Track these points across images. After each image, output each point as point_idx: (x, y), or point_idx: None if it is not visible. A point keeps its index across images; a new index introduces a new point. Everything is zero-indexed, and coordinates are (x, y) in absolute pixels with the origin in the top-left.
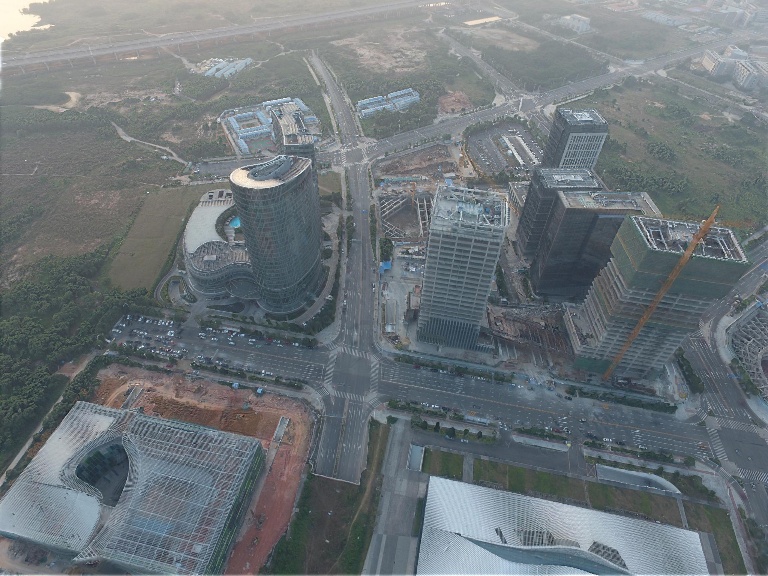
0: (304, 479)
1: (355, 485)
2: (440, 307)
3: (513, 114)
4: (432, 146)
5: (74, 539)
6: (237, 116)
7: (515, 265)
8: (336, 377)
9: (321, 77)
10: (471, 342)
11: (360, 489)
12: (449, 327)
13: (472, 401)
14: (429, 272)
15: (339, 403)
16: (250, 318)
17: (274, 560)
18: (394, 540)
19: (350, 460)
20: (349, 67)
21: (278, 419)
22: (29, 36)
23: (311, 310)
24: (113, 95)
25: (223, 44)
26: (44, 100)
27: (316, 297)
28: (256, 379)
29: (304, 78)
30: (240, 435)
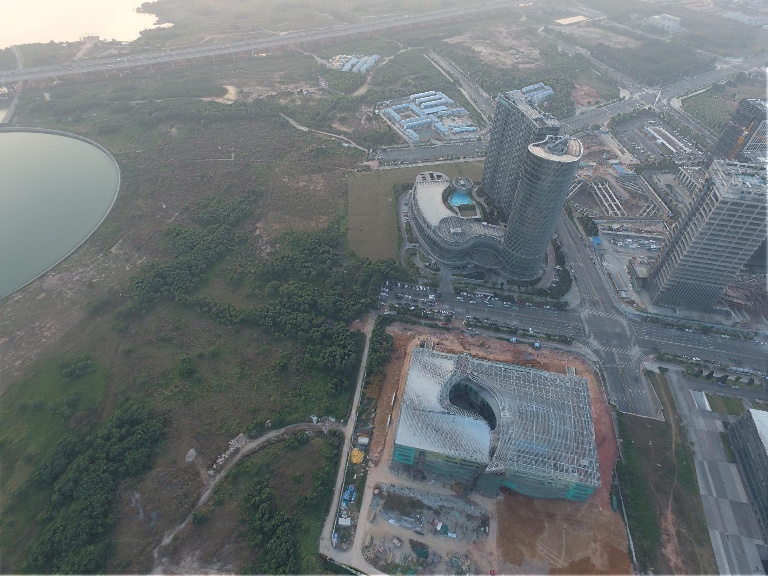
0: (615, 416)
1: (661, 421)
2: (693, 271)
3: (644, 107)
4: (583, 136)
5: (477, 454)
6: (394, 108)
7: None
8: (596, 334)
9: (451, 72)
10: (709, 305)
11: (667, 424)
12: (694, 290)
13: (726, 355)
14: (699, 238)
15: (609, 356)
16: (501, 284)
17: (622, 479)
18: (715, 465)
19: (641, 402)
20: (474, 63)
21: (564, 368)
22: (161, 34)
23: (546, 278)
24: (267, 88)
25: (344, 42)
26: (207, 93)
27: (545, 267)
28: (527, 335)
29: (436, 73)
30: (569, 375)
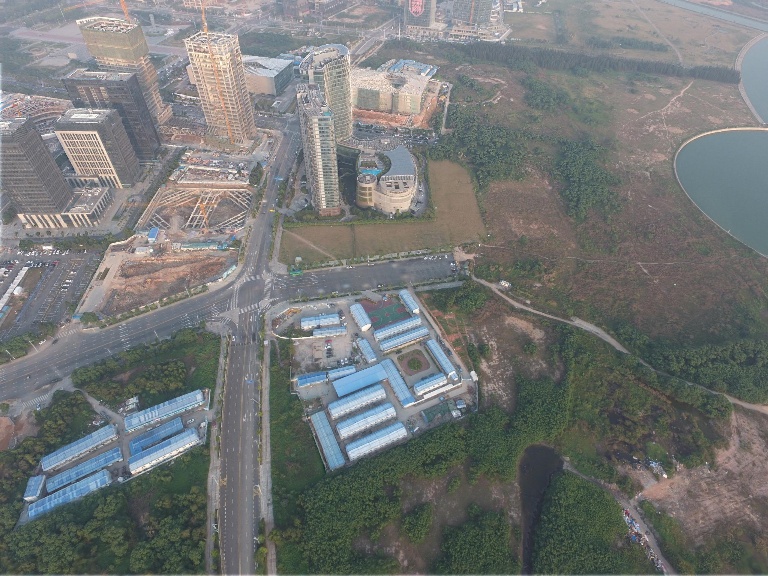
0: None
1: None
2: None
3: None
4: None
5: None
6: (442, 374)
7: (157, 167)
8: None
9: None
10: None
11: None
12: None
13: None
14: None
15: None
16: None
17: None
18: (293, 91)
19: None
20: None
21: None
22: None
23: None
24: (759, 487)
25: None
26: None
27: None
28: None
29: None
30: None
